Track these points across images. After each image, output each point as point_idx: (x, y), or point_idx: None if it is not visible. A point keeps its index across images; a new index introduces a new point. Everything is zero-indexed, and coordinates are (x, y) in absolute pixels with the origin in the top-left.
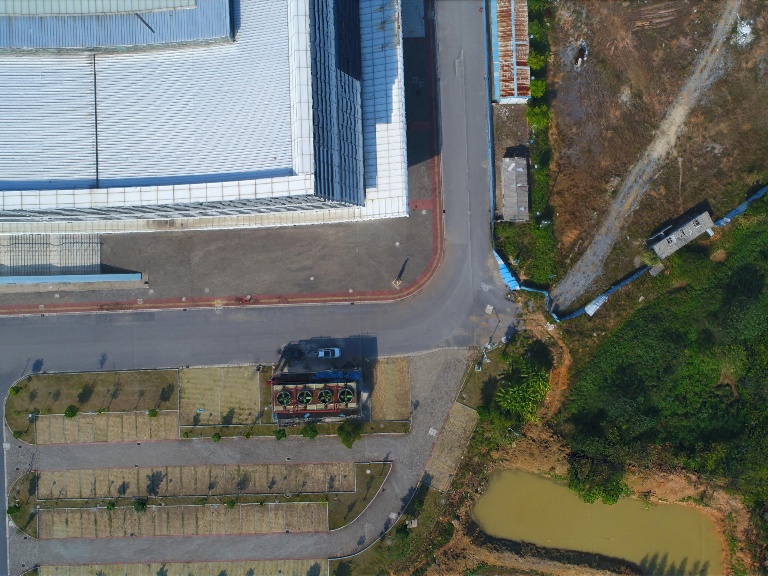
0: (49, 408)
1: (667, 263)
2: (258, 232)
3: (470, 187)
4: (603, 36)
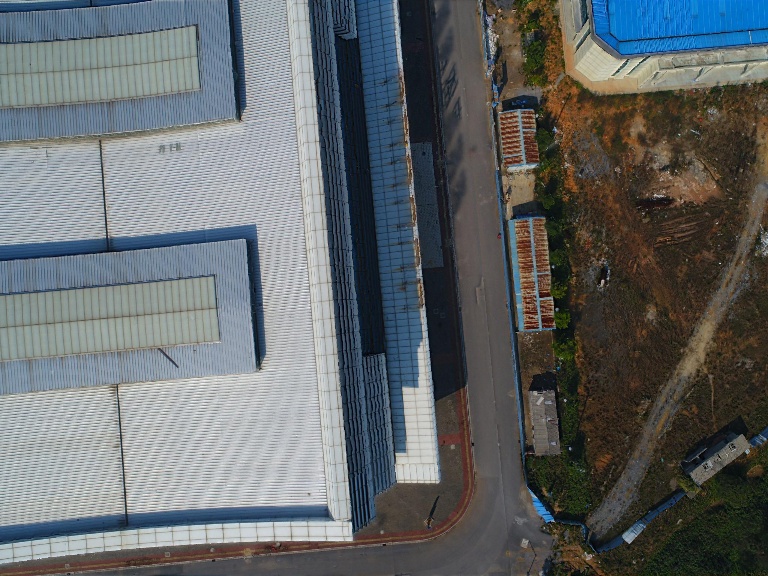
0: None
1: (704, 484)
2: None
3: (498, 418)
4: (625, 254)
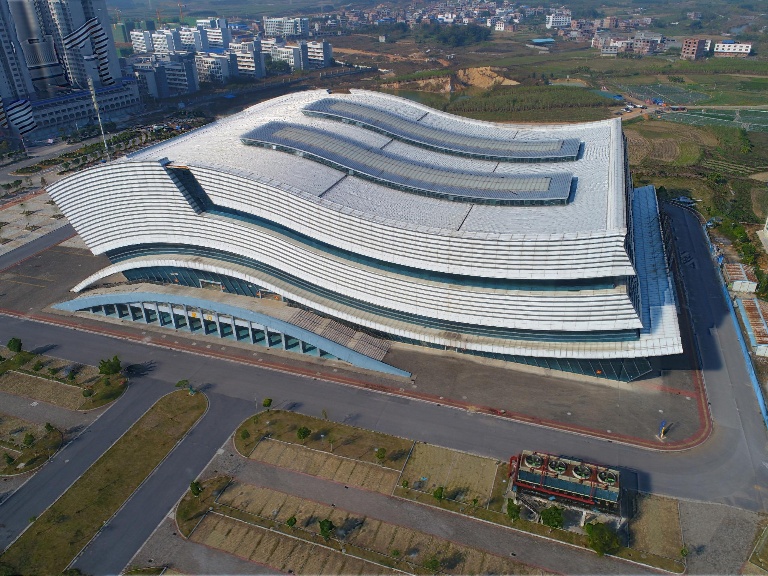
0: (279, 435)
1: None
2: (523, 374)
3: (735, 394)
4: None
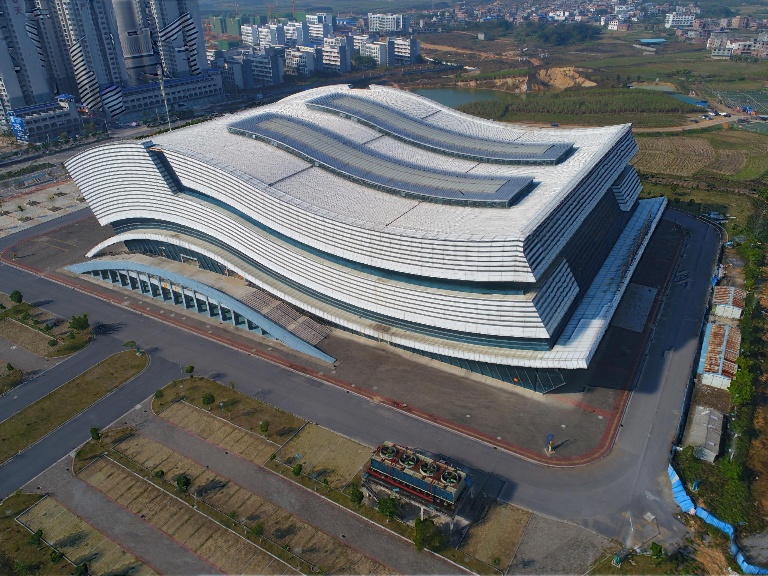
0: (193, 399)
1: None
2: (443, 373)
3: (656, 420)
4: None
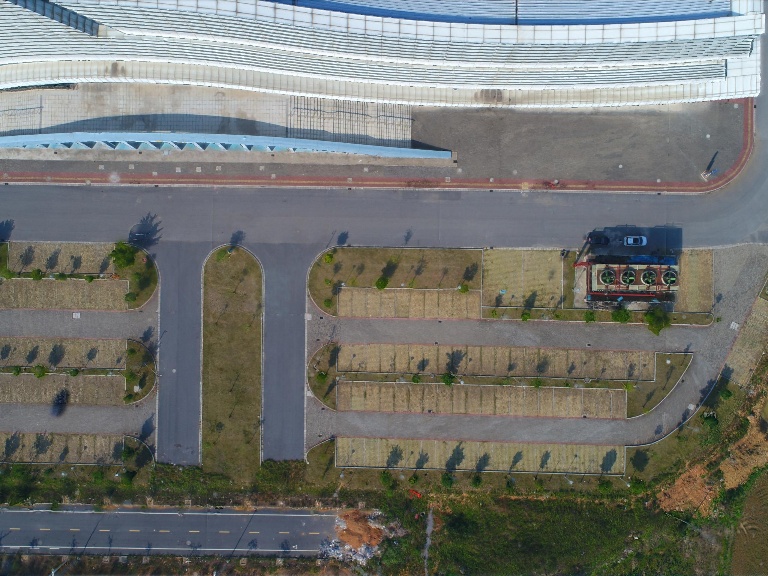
0: (353, 281)
1: None
2: (570, 117)
3: None
4: None
